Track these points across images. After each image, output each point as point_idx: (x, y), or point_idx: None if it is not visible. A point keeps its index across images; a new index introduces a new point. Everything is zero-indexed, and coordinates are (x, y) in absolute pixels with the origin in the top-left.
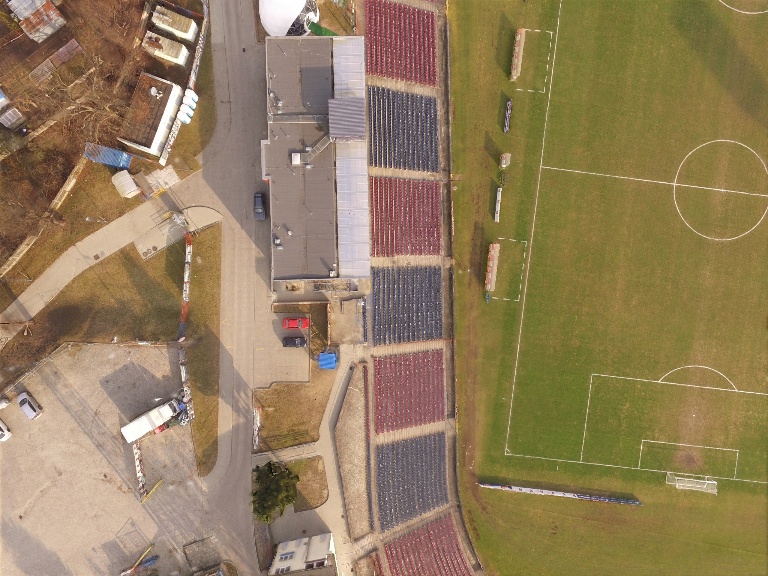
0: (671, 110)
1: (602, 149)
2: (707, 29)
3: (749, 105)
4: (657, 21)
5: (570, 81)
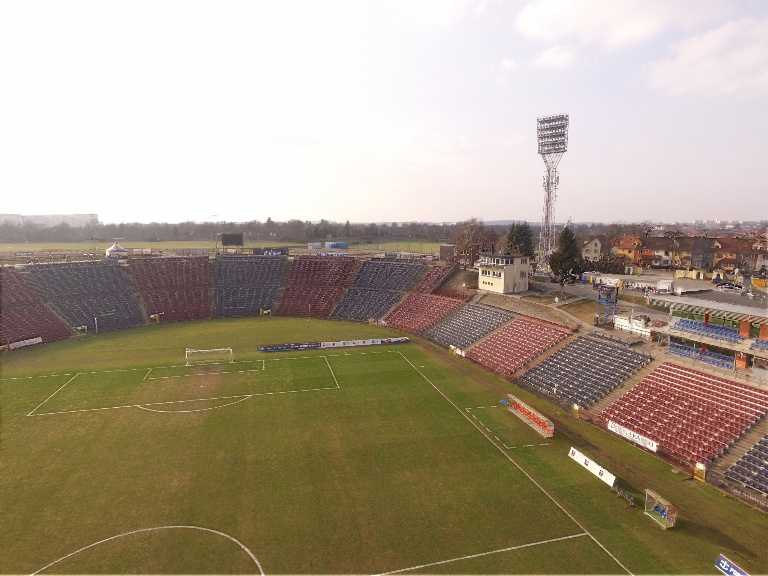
0: None
1: None
2: None
3: None
4: None
5: None
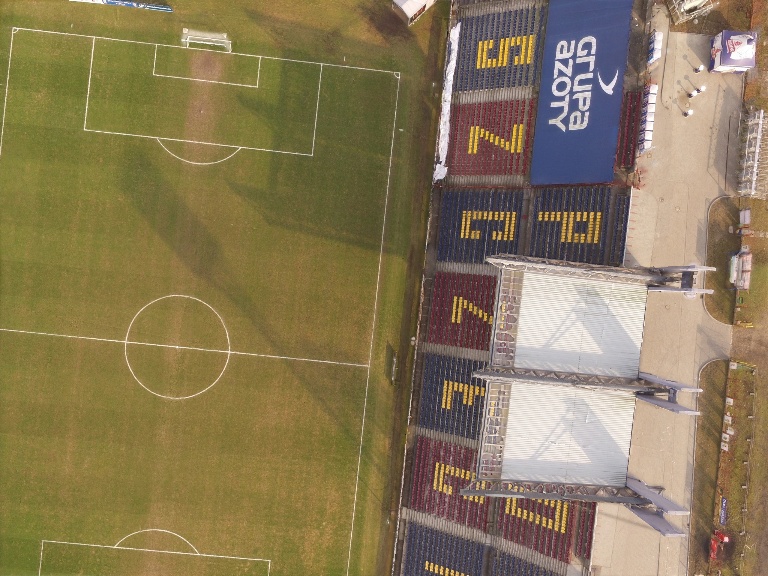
0: (120, 266)
1: (47, 308)
2: (156, 181)
3: (203, 258)
4: (102, 175)
5: (11, 238)
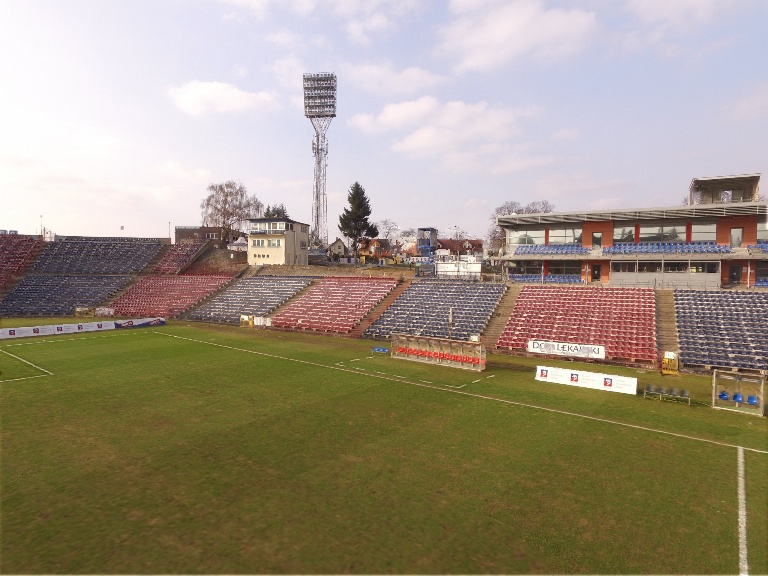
0: None
1: None
2: None
3: None
4: None
5: None
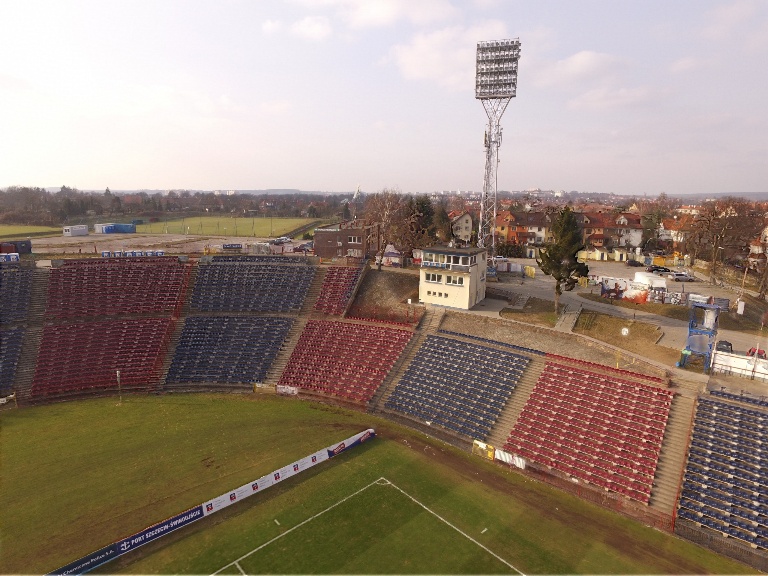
0: None
1: None
2: None
3: None
4: None
5: None
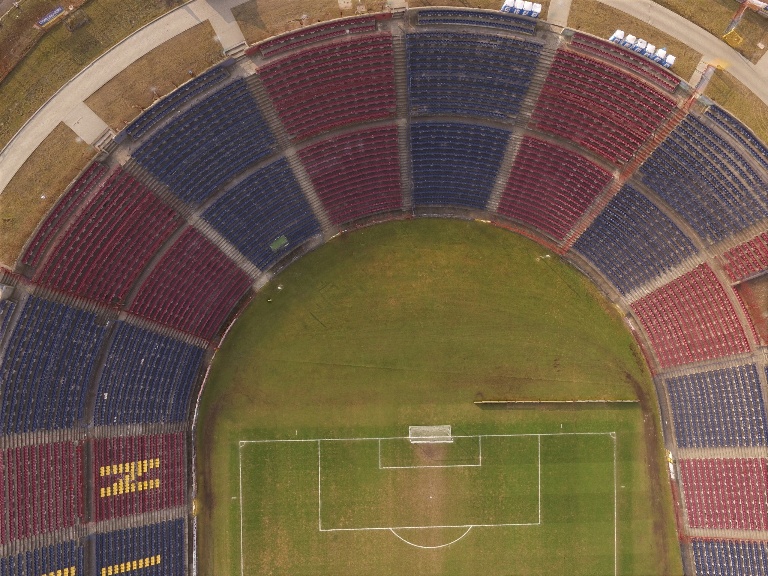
0: None
1: None
2: None
3: None
4: None
5: None
